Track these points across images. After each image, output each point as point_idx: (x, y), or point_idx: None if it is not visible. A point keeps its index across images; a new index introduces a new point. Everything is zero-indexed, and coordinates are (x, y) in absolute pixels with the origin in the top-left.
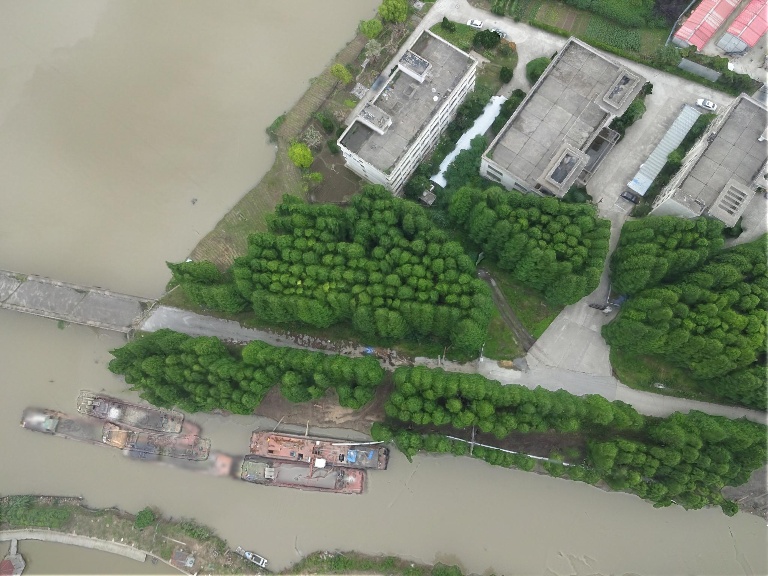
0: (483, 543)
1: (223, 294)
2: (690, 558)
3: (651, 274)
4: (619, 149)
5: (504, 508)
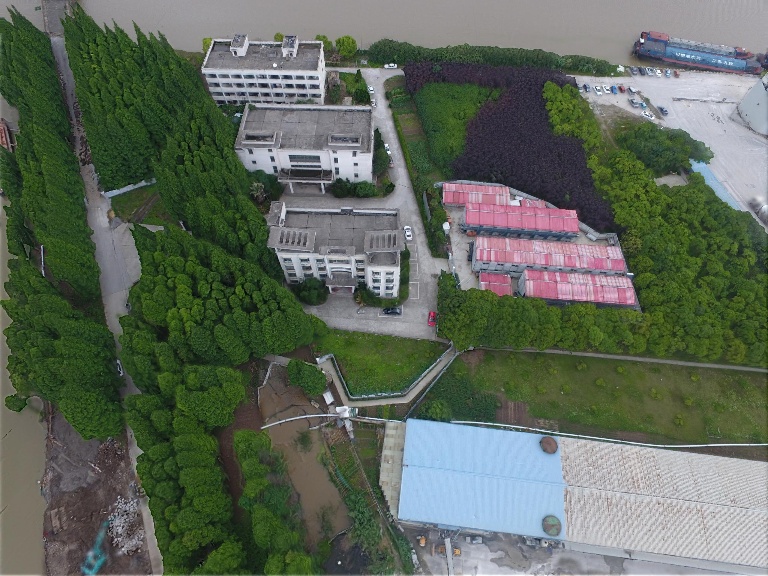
0: None
1: (69, 31)
2: (0, 455)
3: None
4: (334, 201)
5: (4, 294)
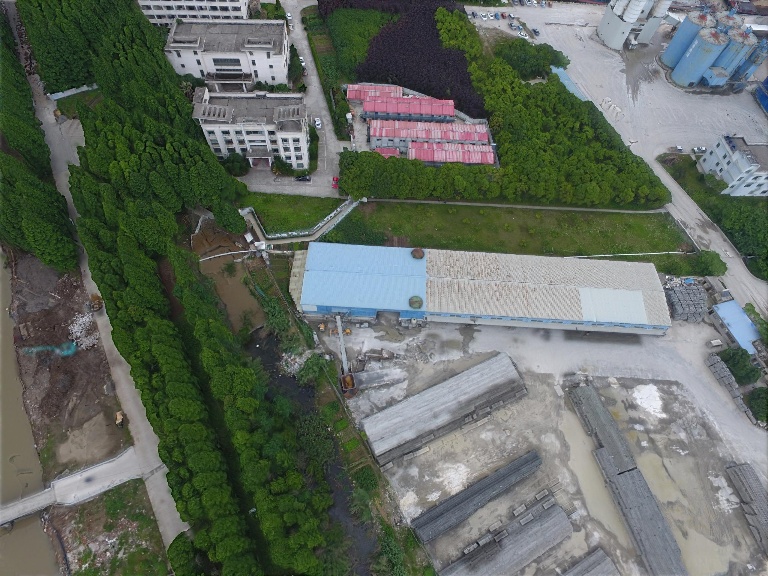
0: None
1: None
2: None
3: None
4: None
5: None
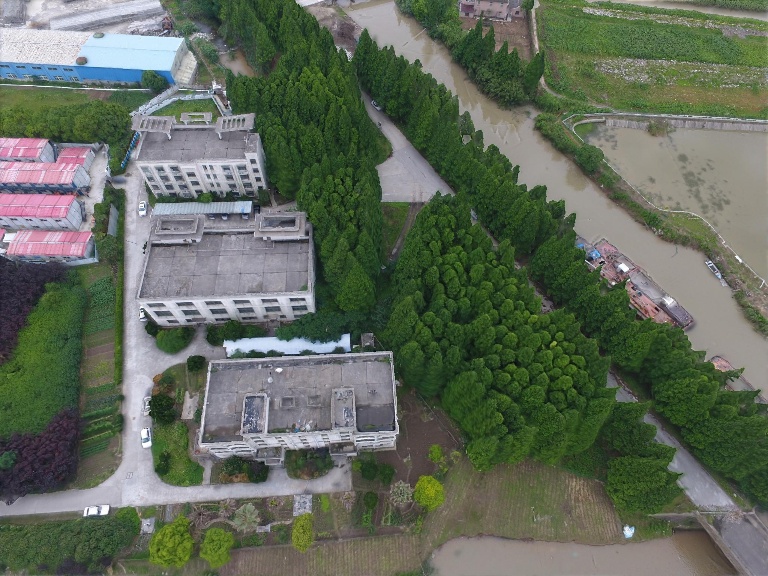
0: (545, 173)
1: None
2: None
3: None
4: None
5: None
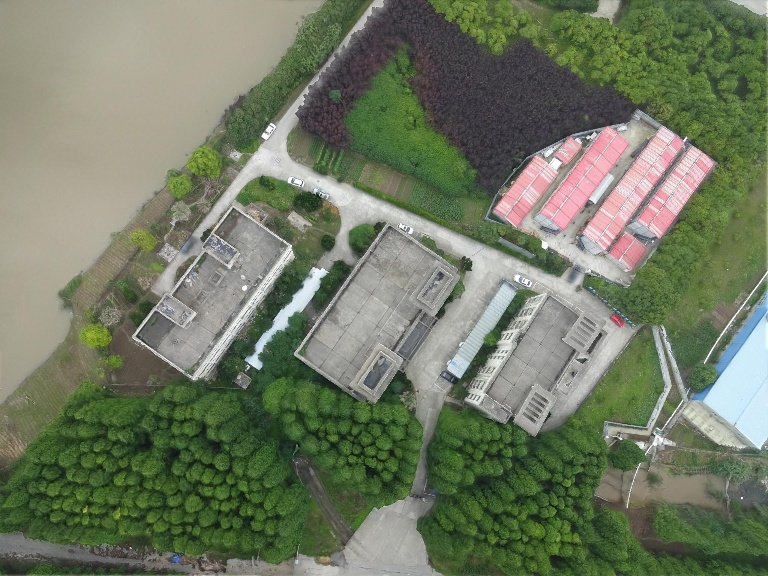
0: None
1: None
2: None
3: (459, 484)
4: (440, 325)
5: None
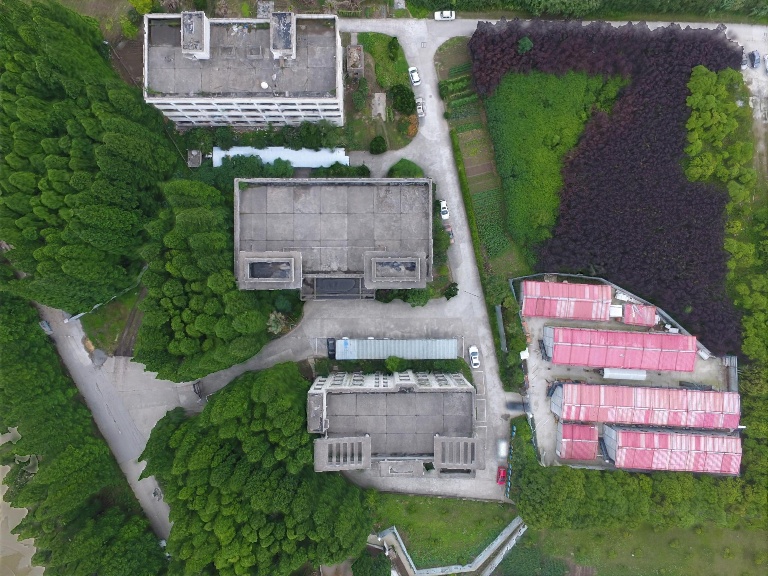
0: None
1: None
2: None
3: None
4: (376, 306)
5: None
